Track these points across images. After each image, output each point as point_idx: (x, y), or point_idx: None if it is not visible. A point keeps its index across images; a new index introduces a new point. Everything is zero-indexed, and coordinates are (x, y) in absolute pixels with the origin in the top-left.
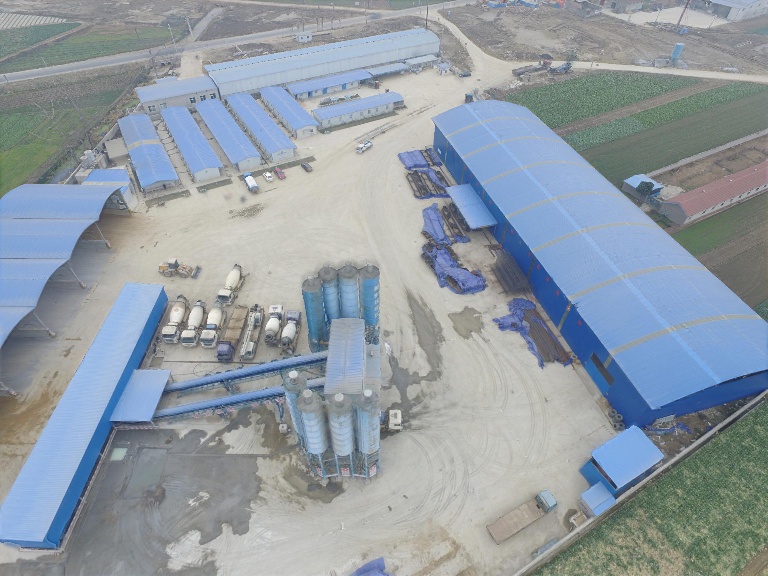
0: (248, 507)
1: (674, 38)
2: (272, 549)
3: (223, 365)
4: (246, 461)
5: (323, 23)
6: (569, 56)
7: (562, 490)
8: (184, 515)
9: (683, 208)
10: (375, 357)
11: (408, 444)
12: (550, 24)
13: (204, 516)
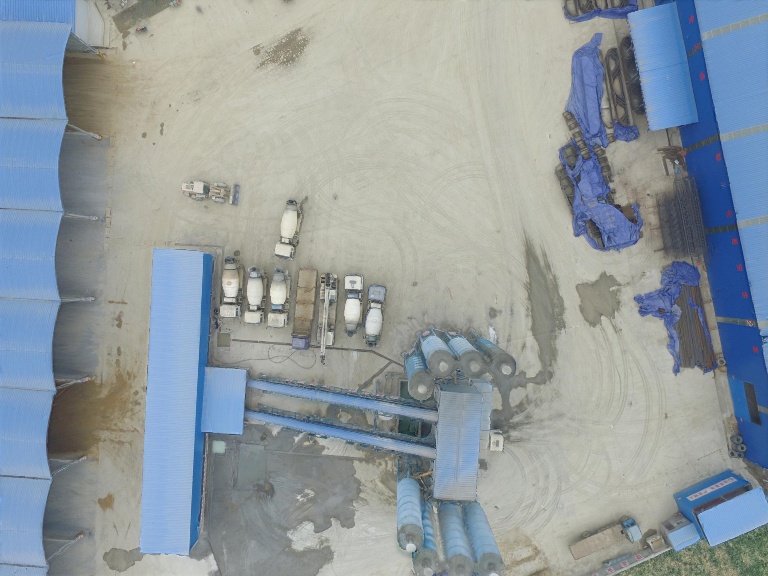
0: (351, 506)
1: None
2: (377, 541)
3: (301, 355)
4: (343, 463)
5: None
6: None
7: (649, 512)
8: (296, 509)
9: None
10: (485, 402)
11: (505, 457)
12: None
13: (313, 511)
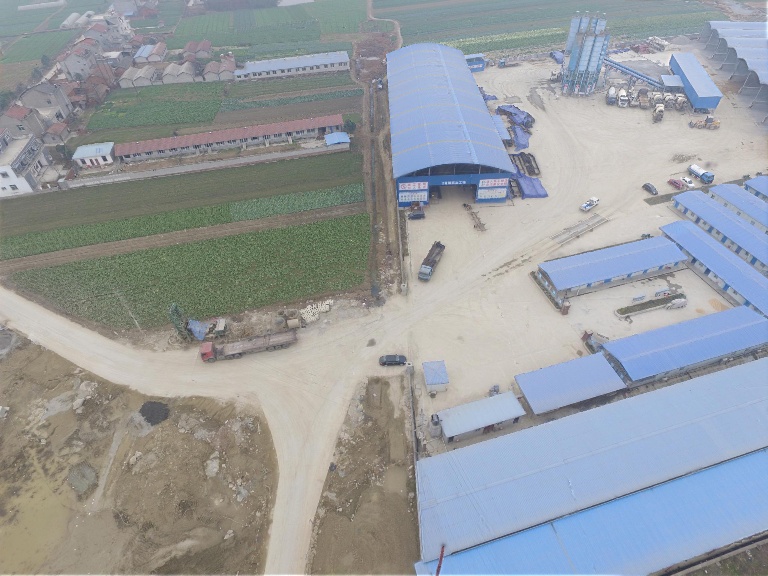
0: None
1: None
2: None
3: None
4: None
5: None
6: None
7: None
8: None
9: None
10: None
11: None
12: None
13: None
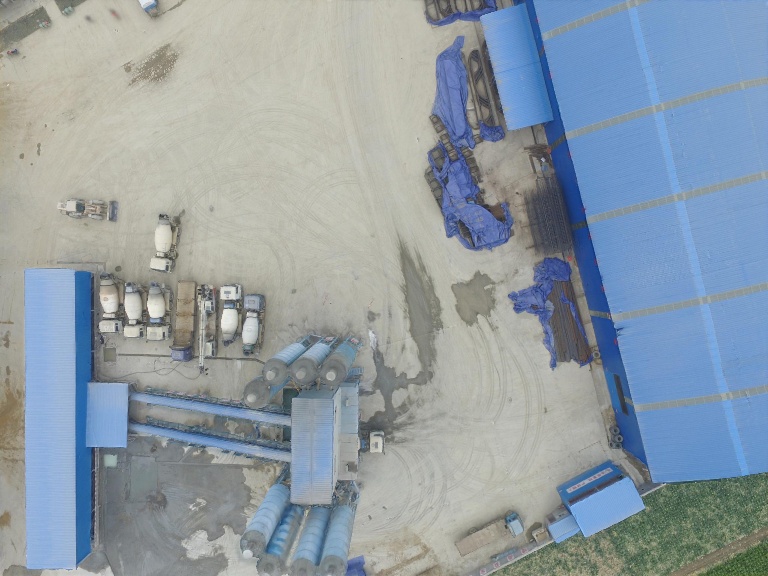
0: (243, 513)
1: None
2: None
3: (184, 366)
4: (232, 471)
5: None
6: None
7: (534, 506)
8: (188, 518)
9: None
10: (351, 406)
11: (390, 458)
12: None
13: (206, 519)
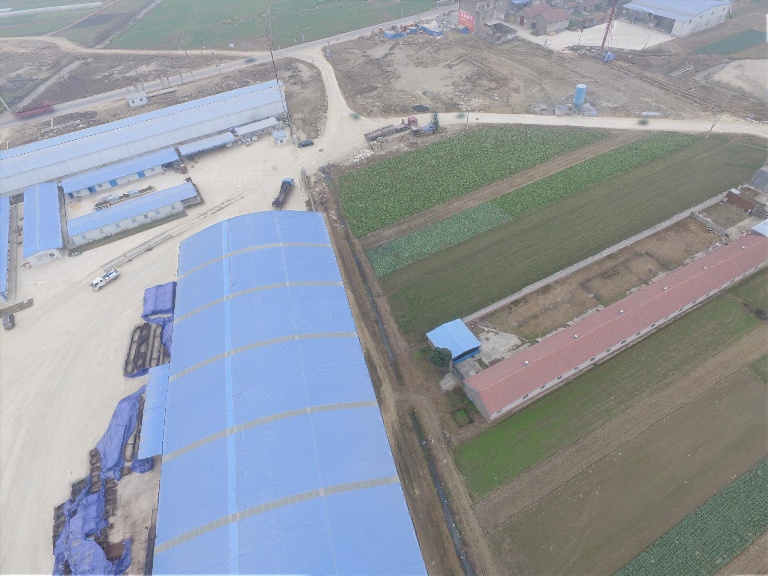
0: None
1: (595, 67)
2: None
3: None
4: None
5: (178, 76)
6: (447, 107)
7: None
8: None
9: (483, 400)
10: None
11: None
12: (449, 57)
13: None
